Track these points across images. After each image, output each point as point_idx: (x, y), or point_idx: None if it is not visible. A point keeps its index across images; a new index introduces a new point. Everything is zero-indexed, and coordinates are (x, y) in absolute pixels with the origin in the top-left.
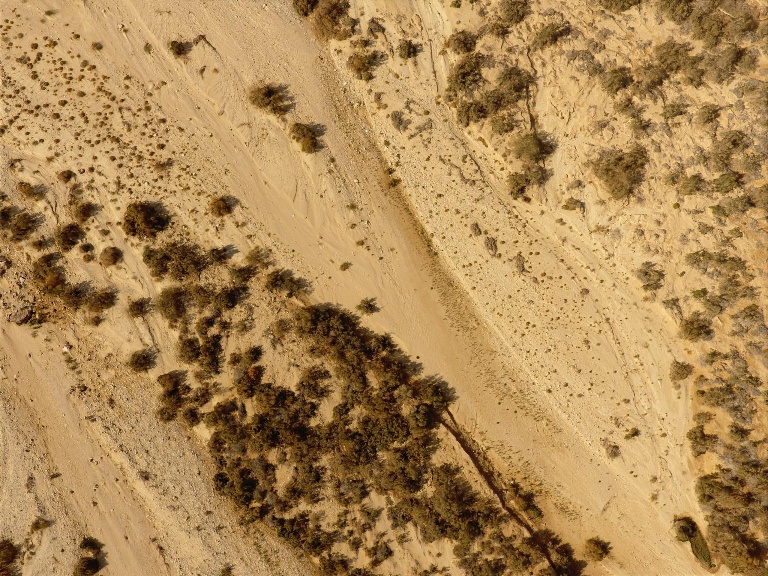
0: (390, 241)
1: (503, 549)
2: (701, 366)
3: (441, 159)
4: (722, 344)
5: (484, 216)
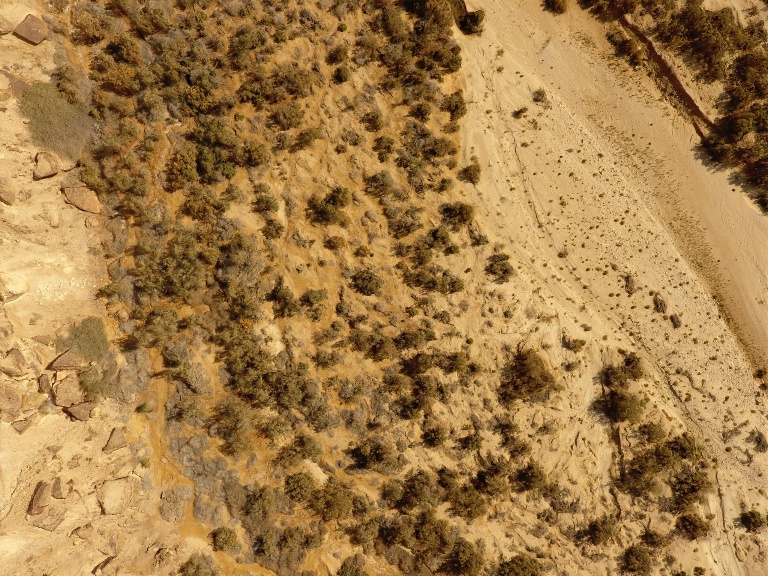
0: (763, 312)
1: (657, 2)
2: (452, 178)
3: (714, 398)
4: (432, 200)
5: (667, 336)
